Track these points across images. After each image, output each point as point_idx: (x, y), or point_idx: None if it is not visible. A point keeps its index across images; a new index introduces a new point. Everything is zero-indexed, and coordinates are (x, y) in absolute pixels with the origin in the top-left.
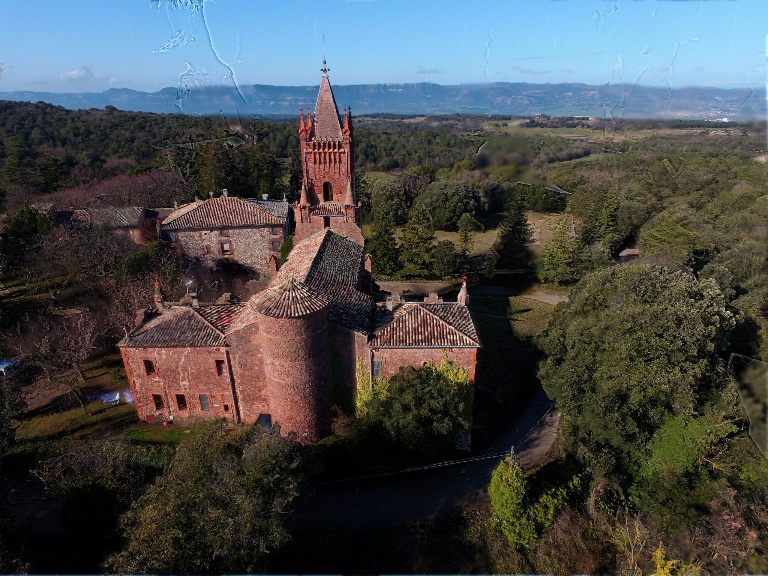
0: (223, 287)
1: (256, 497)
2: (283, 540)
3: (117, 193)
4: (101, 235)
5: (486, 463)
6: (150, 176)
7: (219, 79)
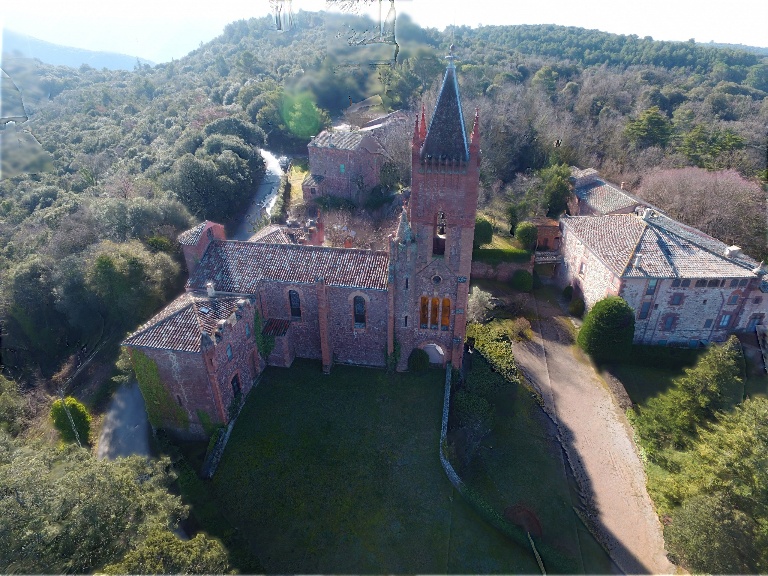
0: (551, 303)
1: (95, 264)
2: (91, 288)
3: (680, 185)
4: (482, 195)
5: (133, 446)
6: (716, 177)
7: (328, 71)
